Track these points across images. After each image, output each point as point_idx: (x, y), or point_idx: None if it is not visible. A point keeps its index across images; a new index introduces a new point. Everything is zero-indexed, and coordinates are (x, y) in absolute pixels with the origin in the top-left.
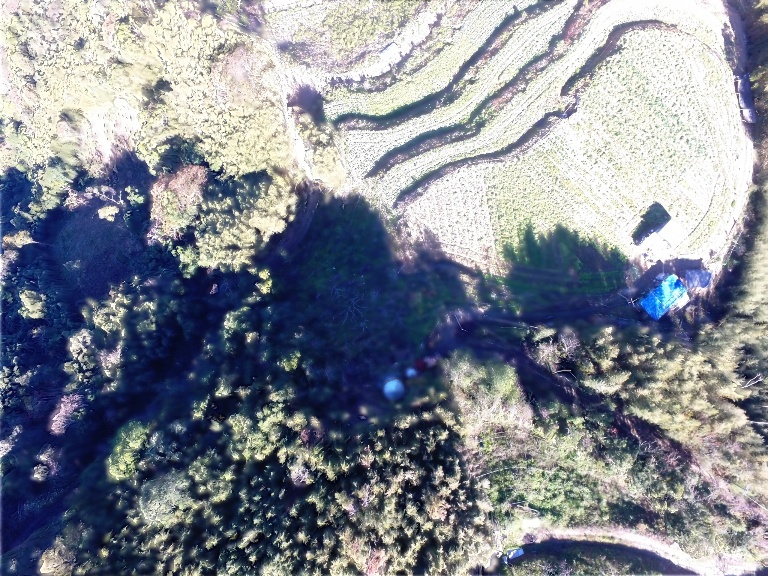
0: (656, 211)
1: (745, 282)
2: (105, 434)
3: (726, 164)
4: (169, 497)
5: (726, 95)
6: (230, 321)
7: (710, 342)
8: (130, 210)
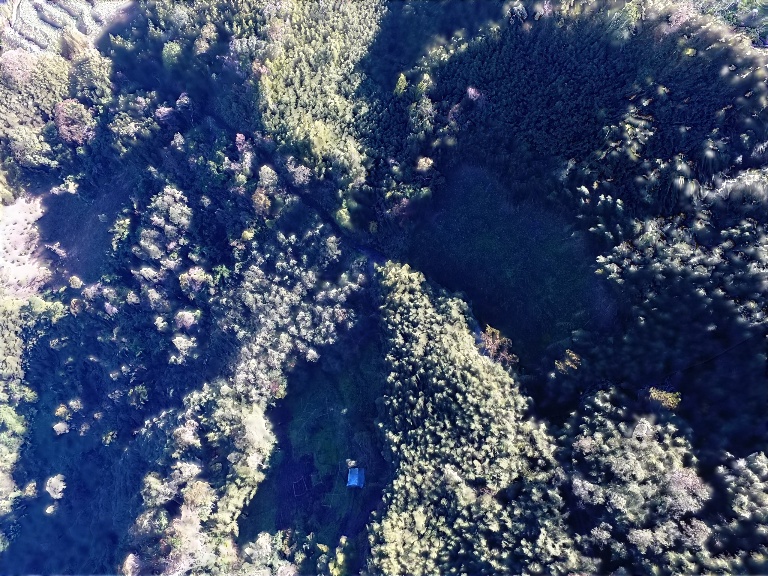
0: None
1: None
2: None
3: None
4: None
5: None
6: None
7: None
8: None
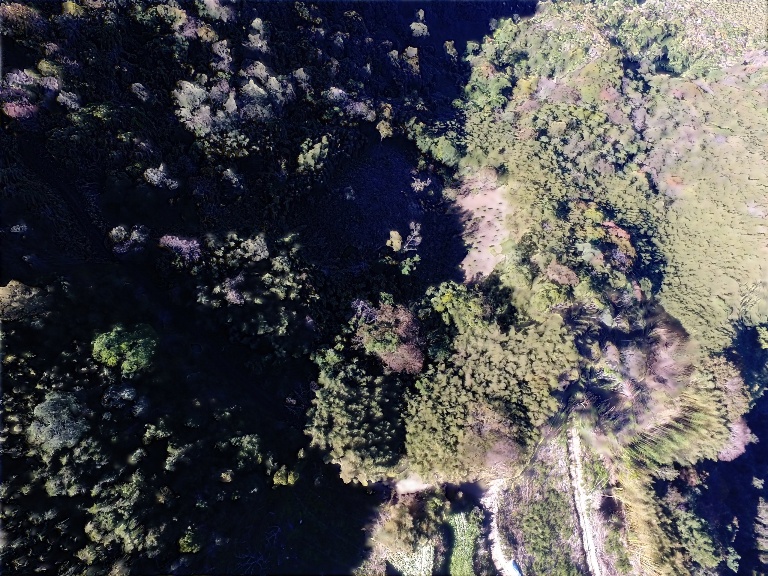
0: None
1: None
2: None
3: None
4: (54, 441)
5: None
6: (248, 445)
7: None
8: None
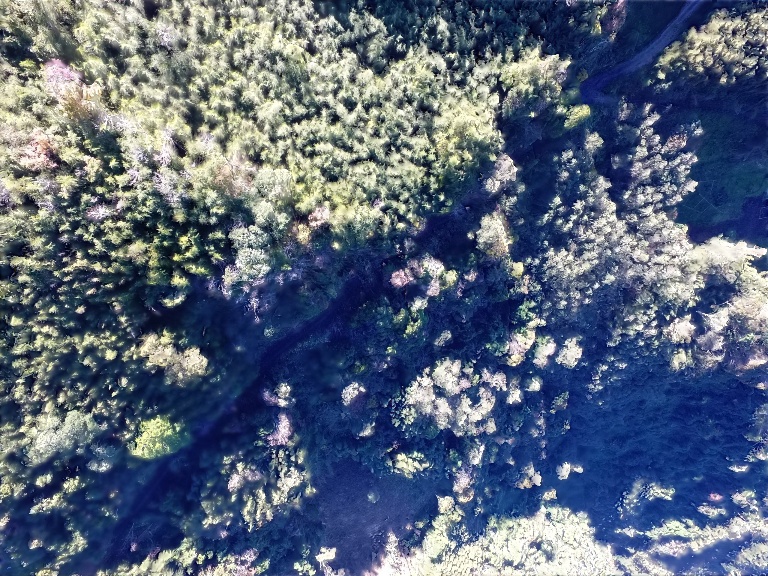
0: None
1: None
2: None
3: None
4: (37, 447)
5: None
6: (74, 547)
7: None
8: None
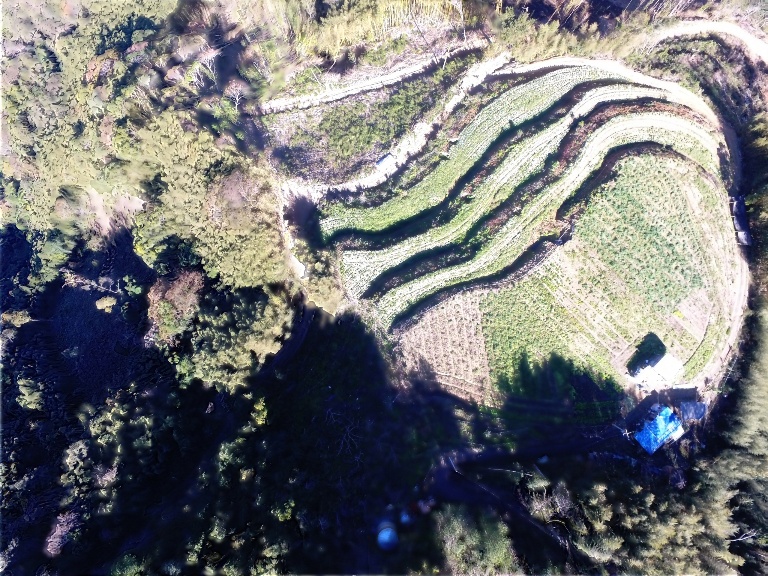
0: (651, 341)
1: (740, 413)
2: (101, 549)
3: (721, 292)
4: None
5: (721, 220)
6: (225, 453)
7: (705, 480)
8: (128, 301)
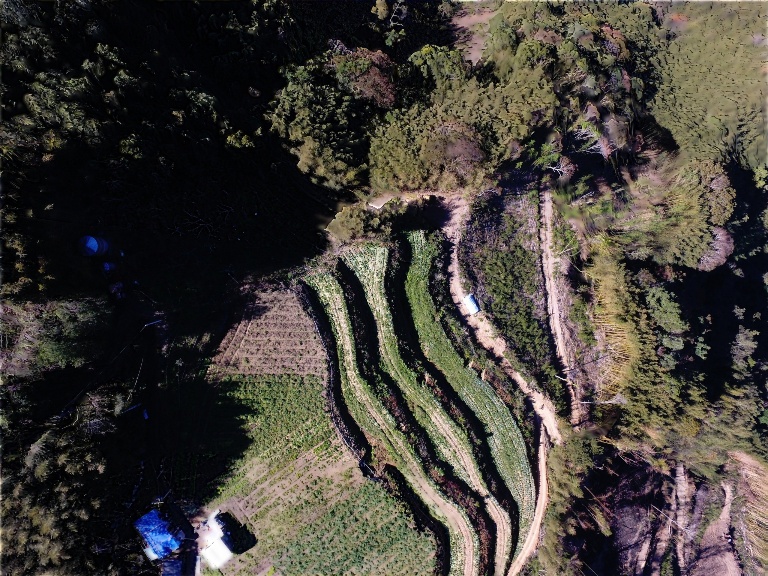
0: (248, 540)
1: None
2: None
3: None
4: None
5: None
6: (204, 99)
7: (98, 574)
8: None
